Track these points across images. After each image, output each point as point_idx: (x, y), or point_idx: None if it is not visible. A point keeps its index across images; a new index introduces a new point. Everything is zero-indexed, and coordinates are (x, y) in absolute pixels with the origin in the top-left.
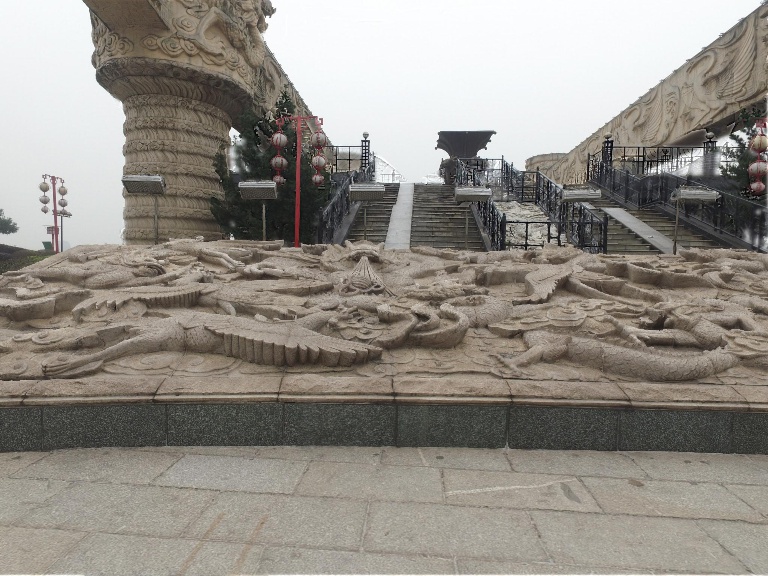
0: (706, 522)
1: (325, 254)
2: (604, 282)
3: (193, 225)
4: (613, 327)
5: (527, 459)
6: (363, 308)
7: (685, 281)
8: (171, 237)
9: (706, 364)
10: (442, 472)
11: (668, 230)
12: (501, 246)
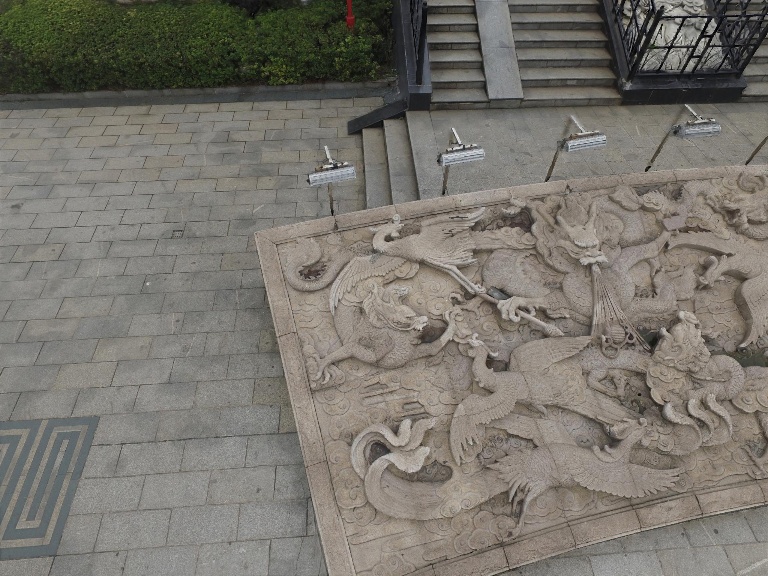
0: None
1: (538, 235)
2: None
3: None
4: None
5: (759, 524)
6: None
7: None
8: None
9: None
10: (725, 551)
11: None
12: (641, 49)
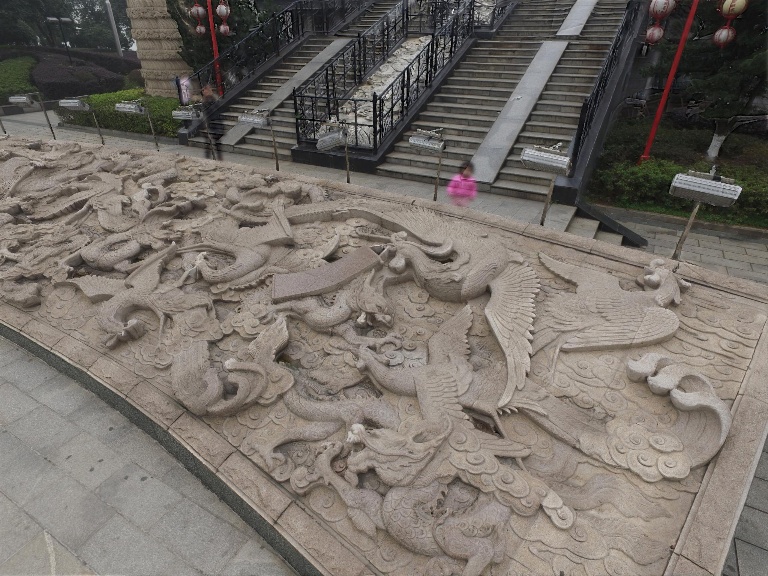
0: None
1: None
2: None
3: (179, 65)
4: None
5: None
6: None
7: None
8: (164, 78)
9: None
10: None
11: (565, 85)
12: None
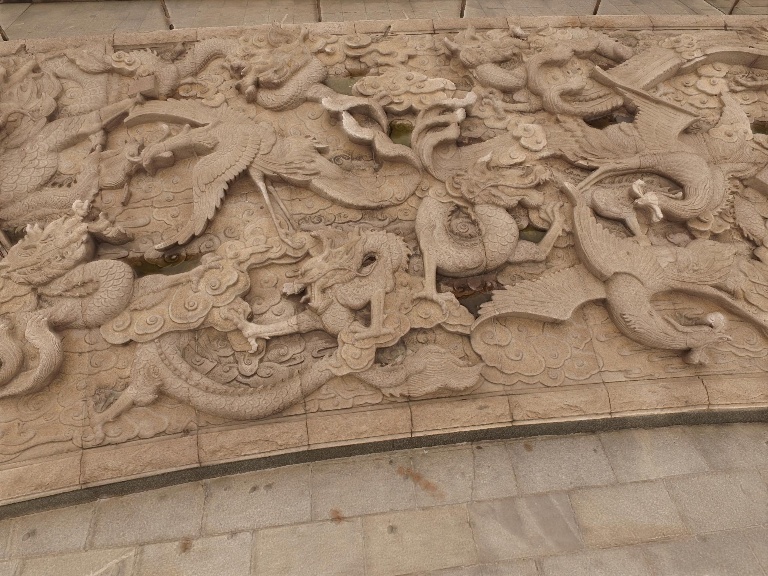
0: None
1: None
2: (289, 178)
3: None
4: (234, 326)
5: (109, 520)
6: None
7: (394, 158)
8: None
9: (292, 398)
10: (16, 570)
11: None
12: None
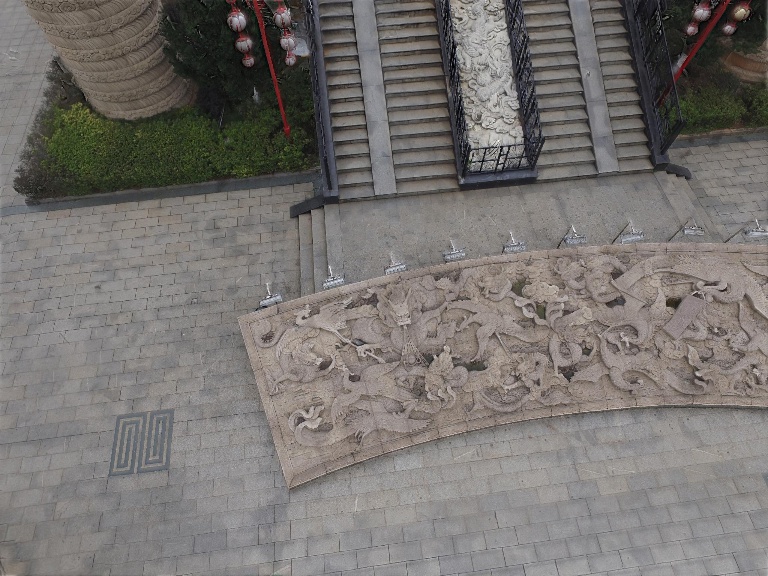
0: (501, 458)
1: (379, 309)
2: None
3: (153, 74)
4: None
5: (470, 438)
6: (416, 375)
7: None
8: (141, 96)
9: None
10: (452, 450)
11: (609, 47)
12: (465, 163)
